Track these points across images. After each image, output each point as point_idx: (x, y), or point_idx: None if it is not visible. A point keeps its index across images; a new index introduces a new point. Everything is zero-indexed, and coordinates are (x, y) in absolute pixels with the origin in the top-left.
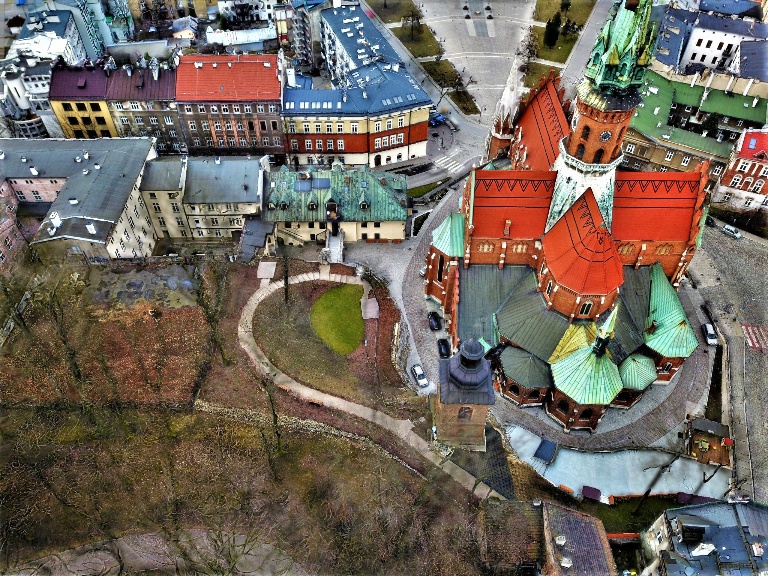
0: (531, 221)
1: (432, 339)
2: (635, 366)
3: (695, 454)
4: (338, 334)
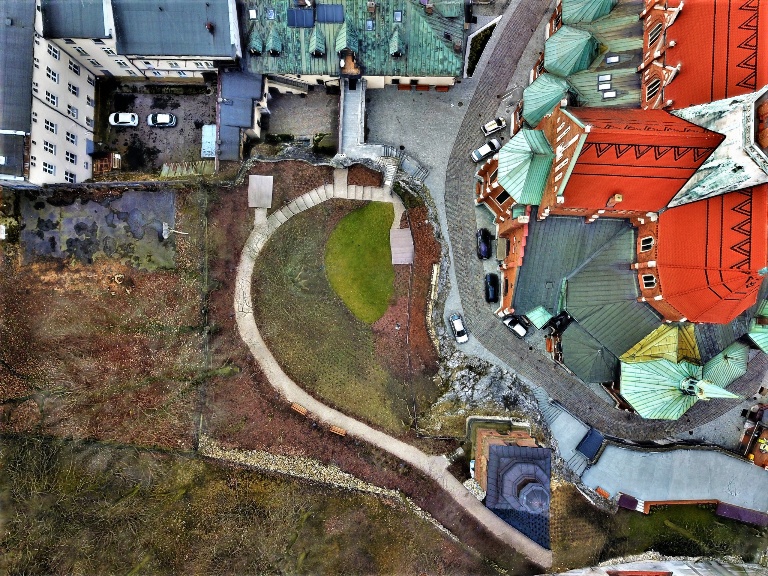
0: (653, 192)
1: (478, 271)
2: (724, 364)
3: (753, 457)
4: (361, 289)
